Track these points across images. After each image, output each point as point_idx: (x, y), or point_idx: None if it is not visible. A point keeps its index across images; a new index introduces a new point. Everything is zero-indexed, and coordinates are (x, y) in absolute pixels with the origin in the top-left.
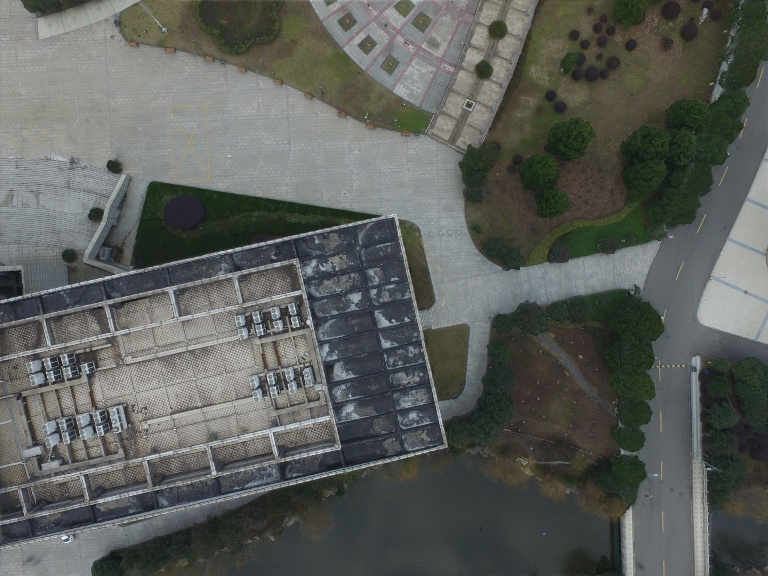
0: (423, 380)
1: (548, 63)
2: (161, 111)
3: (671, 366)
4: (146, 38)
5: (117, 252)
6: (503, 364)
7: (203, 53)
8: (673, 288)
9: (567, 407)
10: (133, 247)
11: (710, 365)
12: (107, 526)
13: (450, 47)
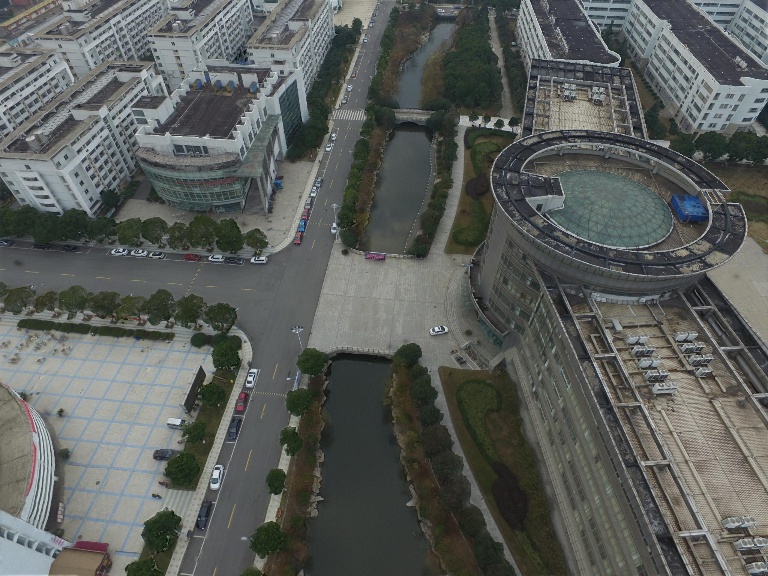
0: None
1: None
2: None
3: None
4: None
5: None
6: None
7: None
8: None
9: None
10: None
11: None
12: (581, 367)
13: None
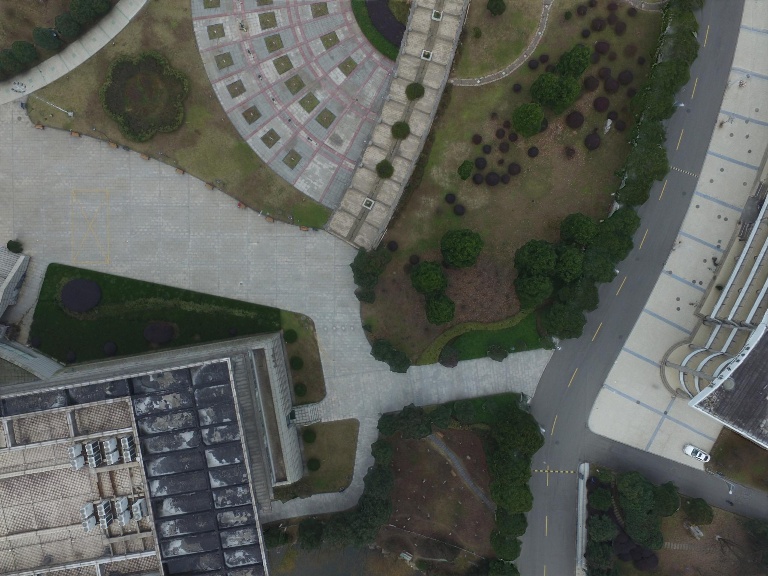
0: (250, 520)
1: (450, 165)
2: (64, 194)
3: (559, 471)
4: (52, 121)
5: (13, 331)
6: (383, 467)
7: (108, 139)
8: (565, 394)
9: (453, 506)
10: (30, 326)
11: (595, 475)
12: None
13: (353, 145)
